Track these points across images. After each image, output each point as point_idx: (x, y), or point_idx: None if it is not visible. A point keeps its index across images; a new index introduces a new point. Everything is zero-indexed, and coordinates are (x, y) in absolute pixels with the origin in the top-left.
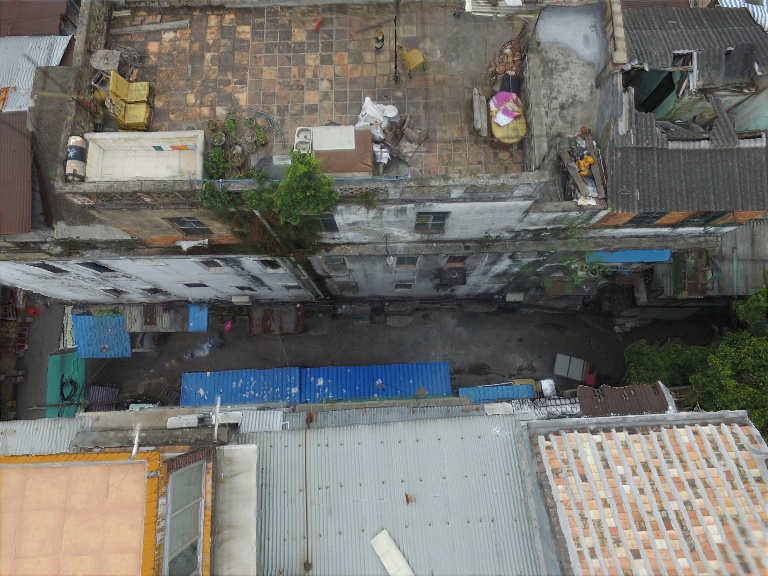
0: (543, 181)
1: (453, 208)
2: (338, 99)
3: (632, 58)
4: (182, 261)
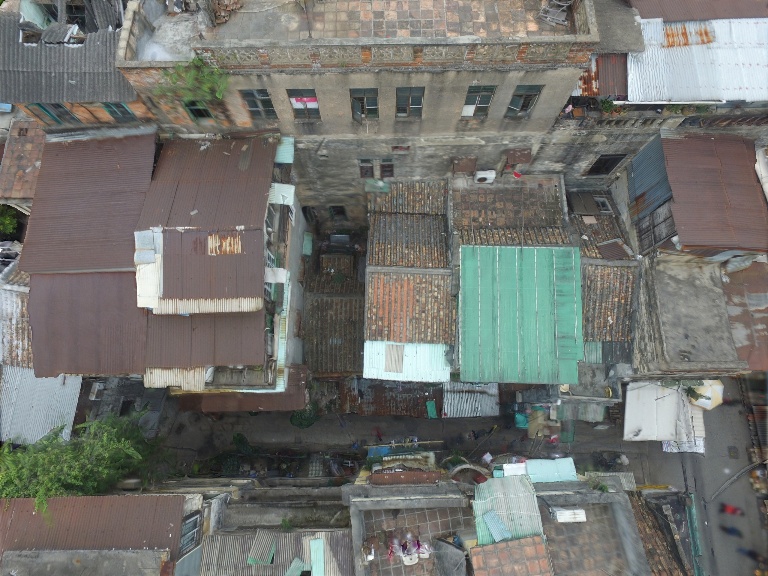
0: None
1: None
2: None
3: None
4: None
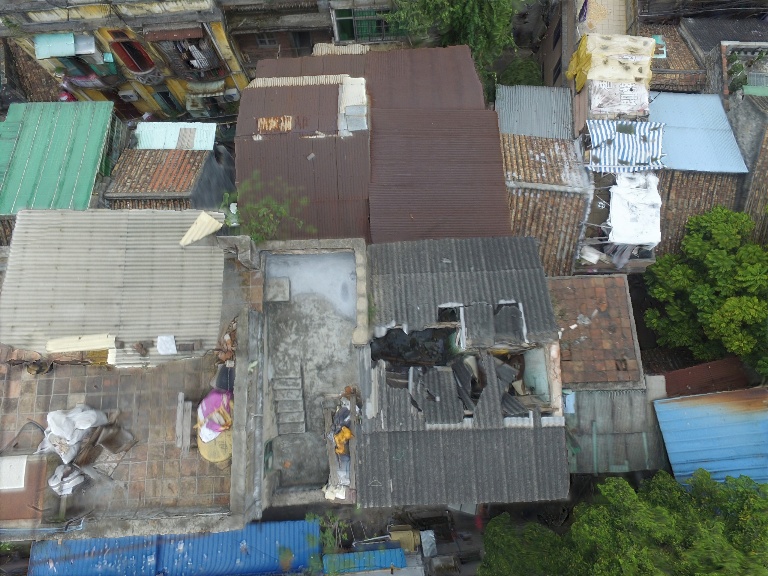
0: None
1: None
2: (42, 391)
3: (388, 320)
4: None
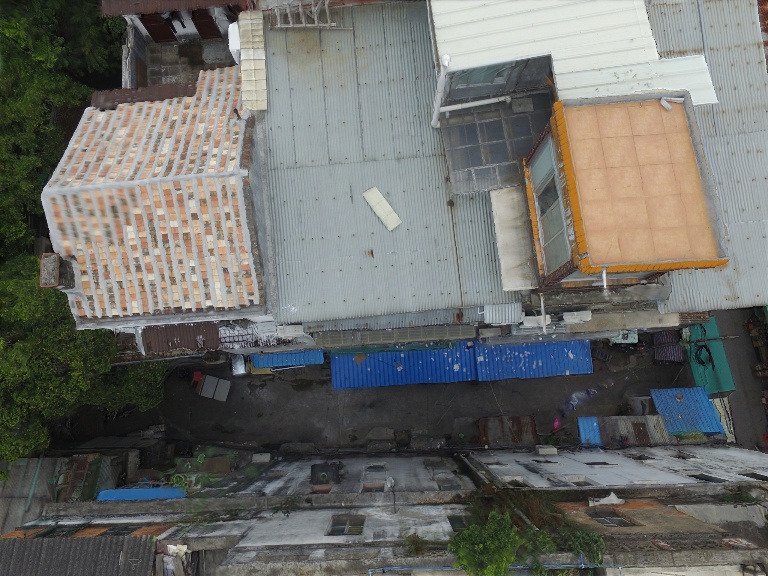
0: (223, 567)
1: (322, 540)
2: None
3: None
4: None
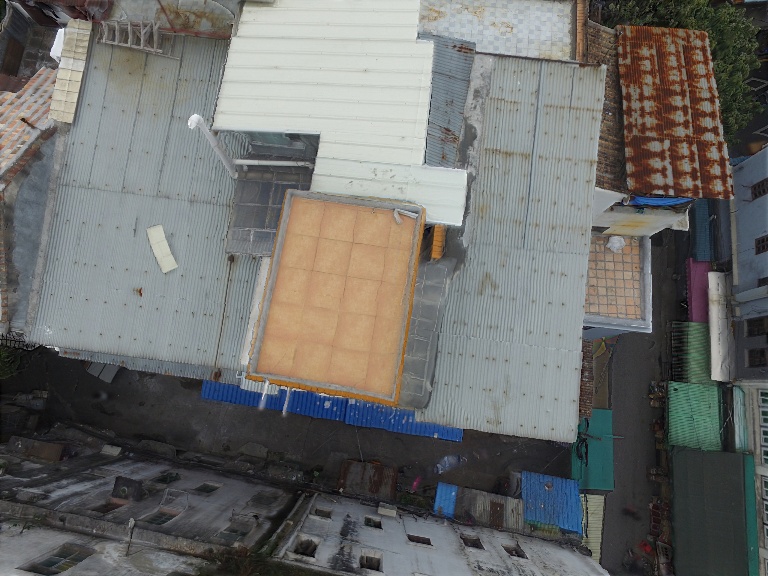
0: None
1: (7, 573)
2: None
3: None
4: (394, 574)
